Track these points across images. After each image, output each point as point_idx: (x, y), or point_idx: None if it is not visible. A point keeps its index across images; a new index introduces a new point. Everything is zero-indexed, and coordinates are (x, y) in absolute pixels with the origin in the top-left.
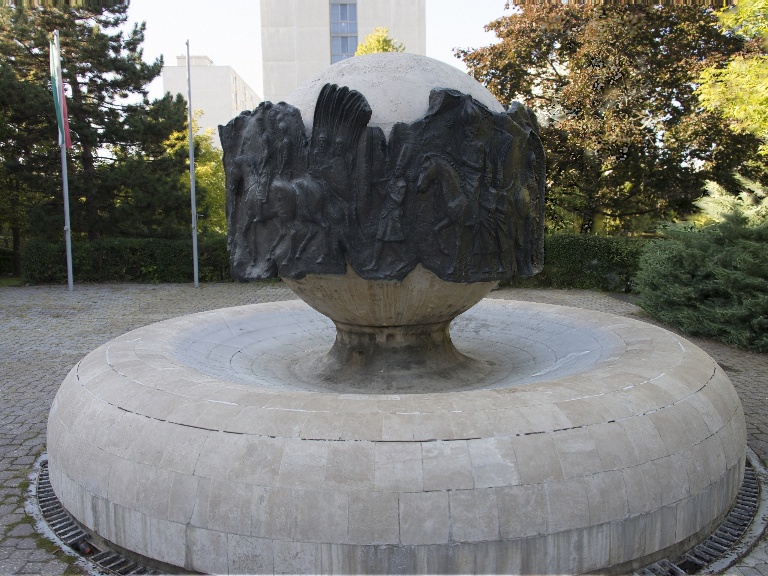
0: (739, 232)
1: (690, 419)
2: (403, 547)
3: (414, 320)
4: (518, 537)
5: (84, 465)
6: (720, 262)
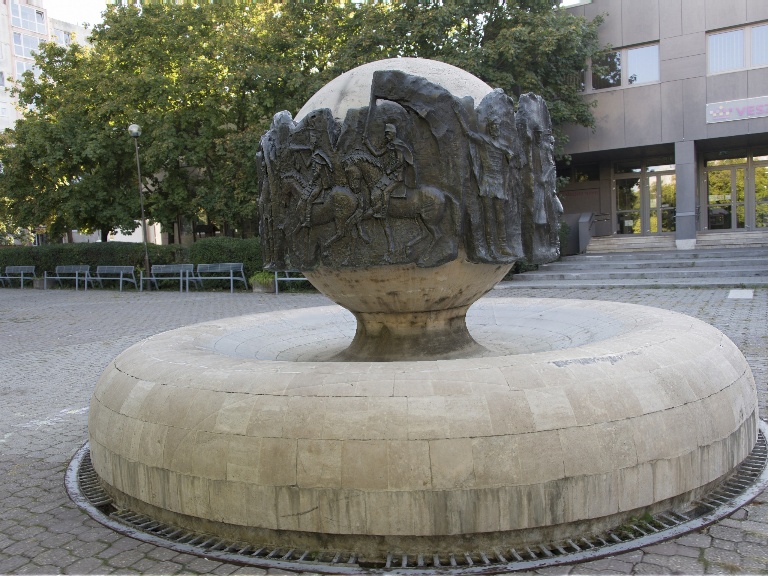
0: None
1: None
2: None
3: None
4: None
5: None
6: None
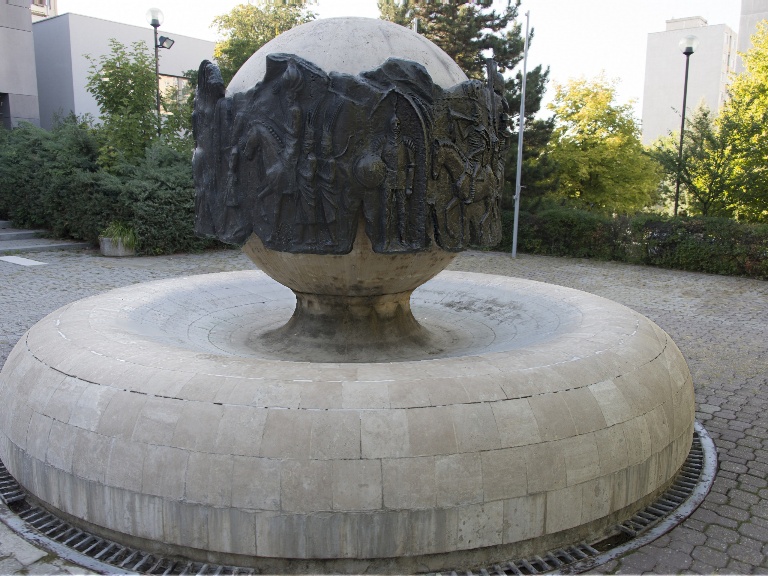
0: None
1: (333, 431)
2: (27, 454)
3: (314, 289)
4: (84, 477)
5: None
6: None
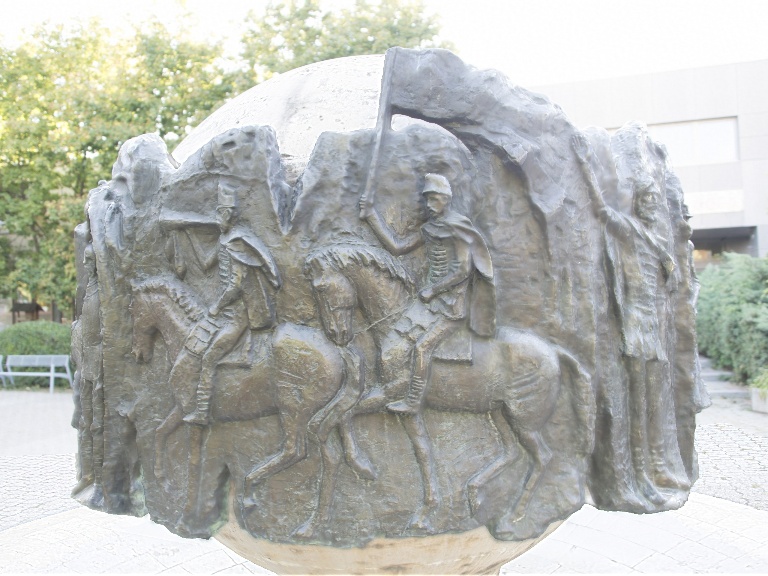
0: None
1: None
2: None
3: None
4: None
5: None
6: None
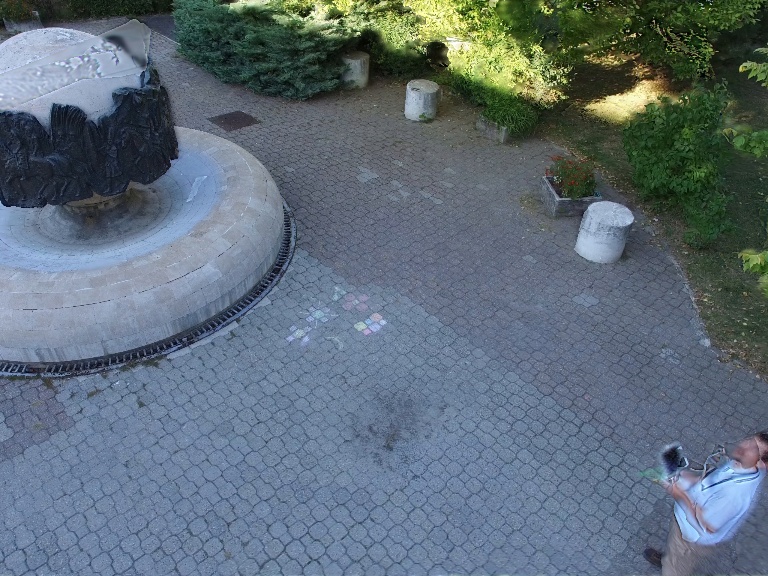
0: (242, 12)
1: (267, 219)
2: (192, 313)
3: None
4: (227, 292)
5: (21, 340)
6: (234, 33)
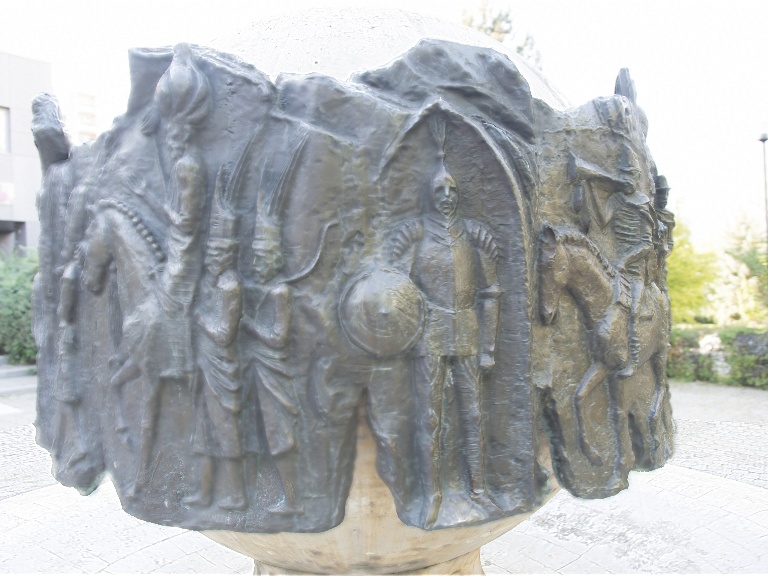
0: None
1: None
2: None
3: None
4: None
5: None
6: None
